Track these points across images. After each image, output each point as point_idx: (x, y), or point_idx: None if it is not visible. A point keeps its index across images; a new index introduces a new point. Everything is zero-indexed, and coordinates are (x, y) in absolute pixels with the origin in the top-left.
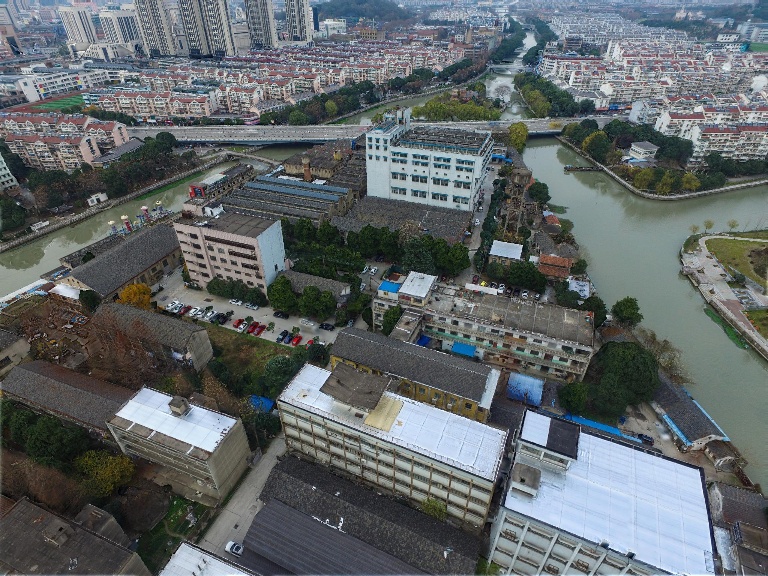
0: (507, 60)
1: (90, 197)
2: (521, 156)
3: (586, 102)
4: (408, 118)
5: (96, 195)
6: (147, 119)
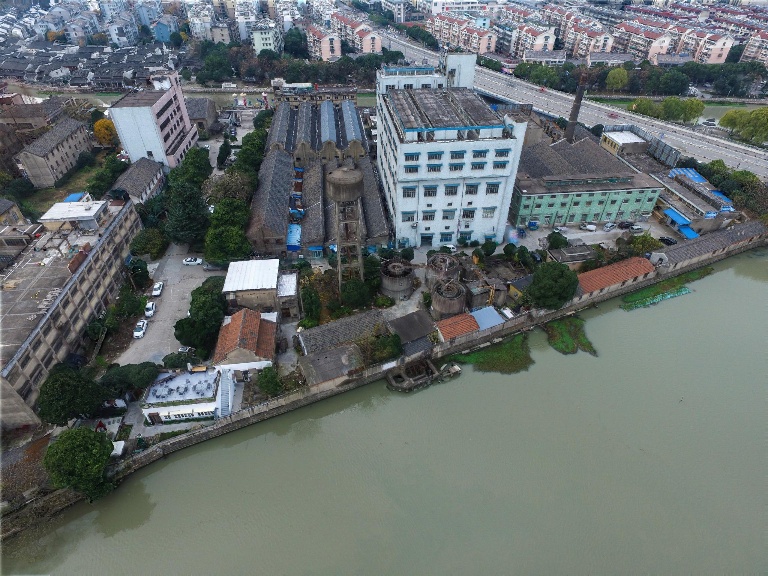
0: None
1: (274, 79)
2: None
3: None
4: (466, 71)
5: (279, 79)
6: (445, 45)
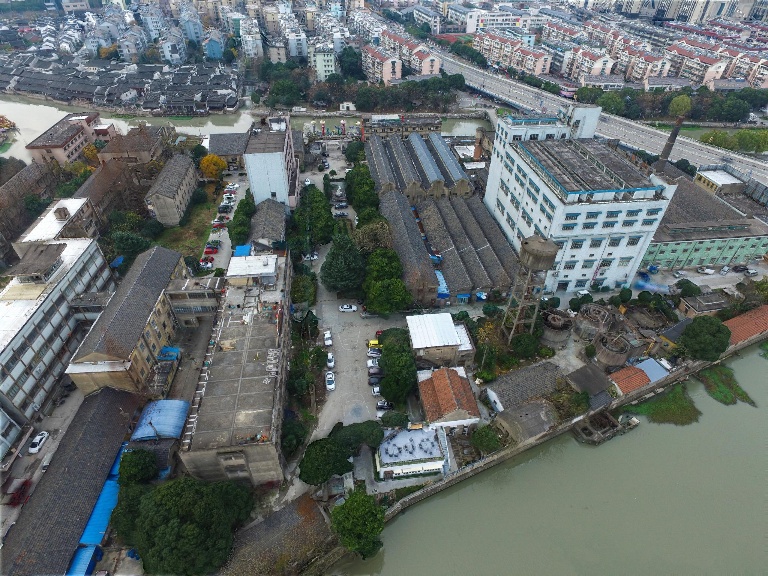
0: None
1: (343, 103)
2: None
3: None
4: (590, 122)
5: (348, 103)
6: (494, 64)
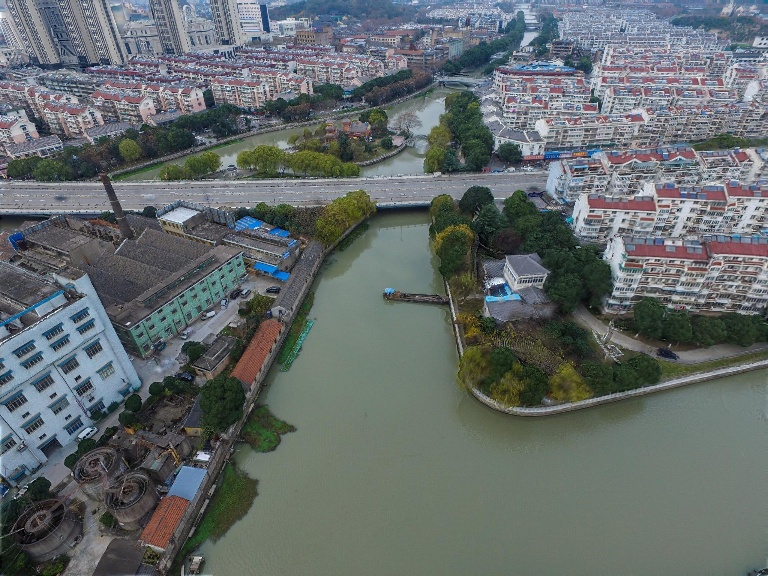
0: (467, 70)
1: None
2: (367, 243)
3: (506, 147)
4: None
5: None
6: None
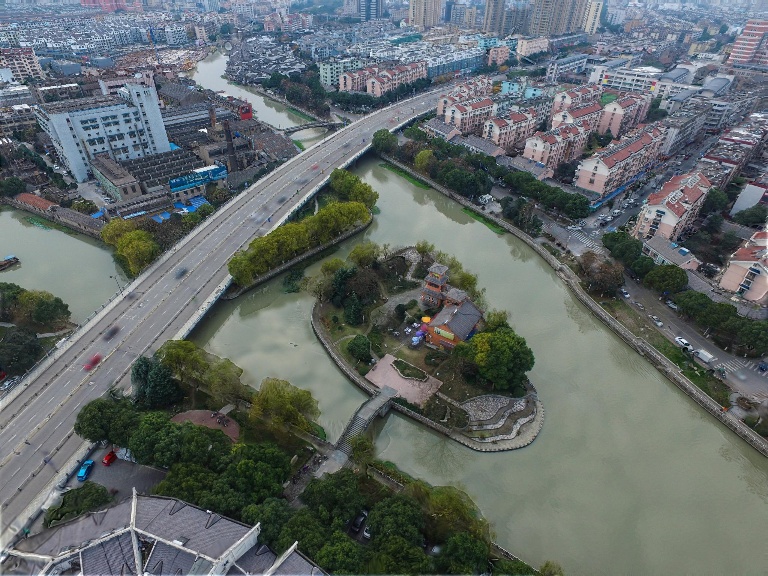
0: None
1: None
2: None
3: (77, 488)
4: None
5: None
6: None
